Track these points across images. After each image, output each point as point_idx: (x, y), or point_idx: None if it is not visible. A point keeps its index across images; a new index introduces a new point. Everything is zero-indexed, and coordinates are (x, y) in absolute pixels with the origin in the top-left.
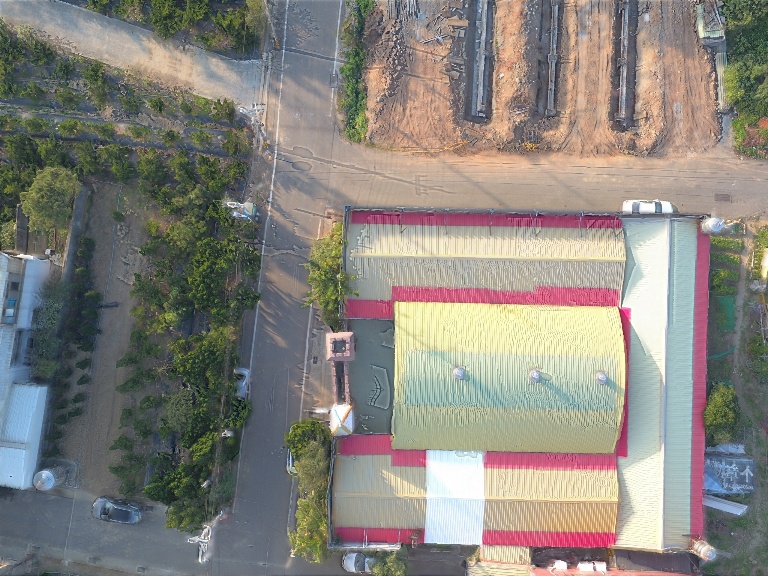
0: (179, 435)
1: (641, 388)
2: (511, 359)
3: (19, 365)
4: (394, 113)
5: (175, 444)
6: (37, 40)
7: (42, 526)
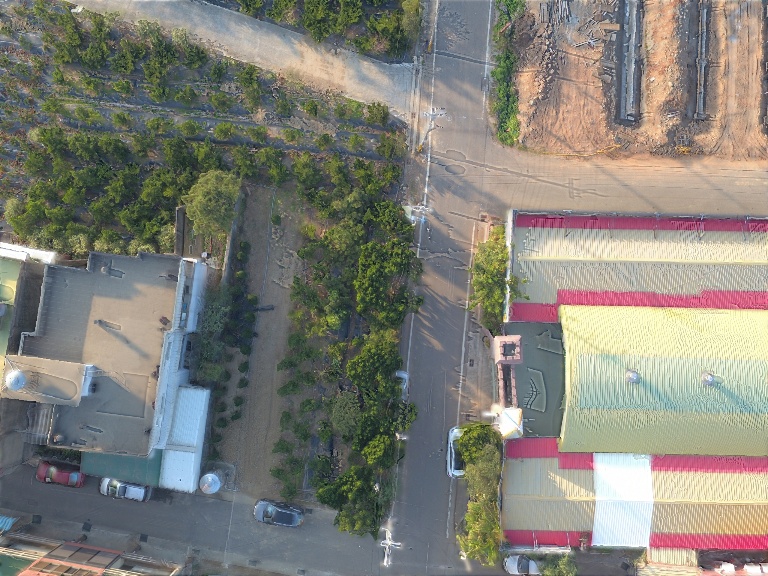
0: (337, 438)
1: None
2: (680, 362)
3: (182, 368)
4: (547, 116)
5: (333, 447)
6: (189, 43)
7: (202, 529)
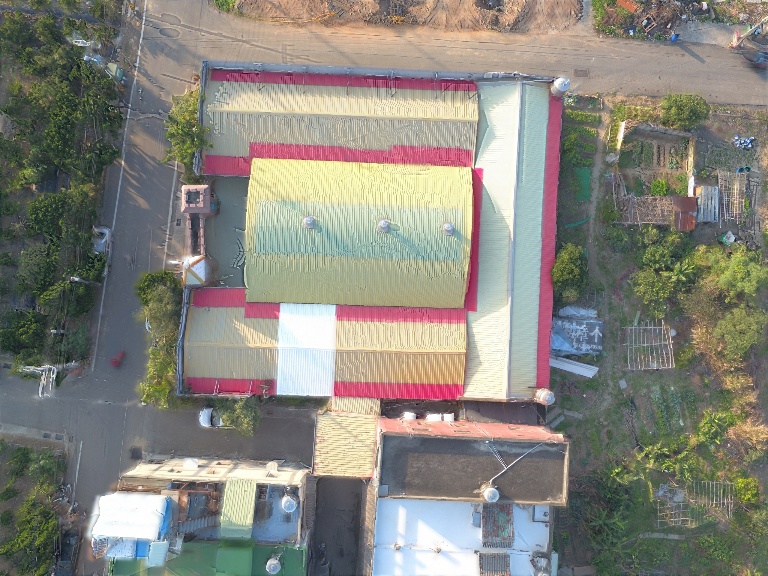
0: None
1: (491, 244)
2: (363, 212)
3: None
4: None
5: (35, 303)
6: None
7: None
